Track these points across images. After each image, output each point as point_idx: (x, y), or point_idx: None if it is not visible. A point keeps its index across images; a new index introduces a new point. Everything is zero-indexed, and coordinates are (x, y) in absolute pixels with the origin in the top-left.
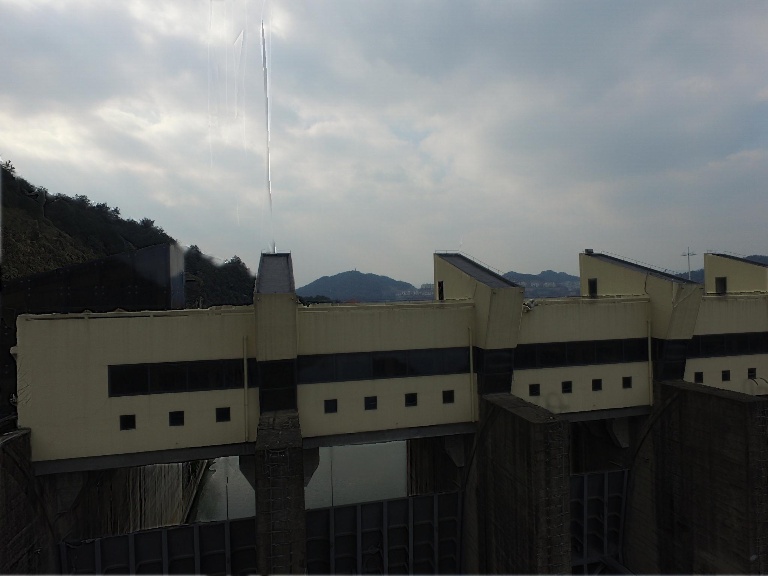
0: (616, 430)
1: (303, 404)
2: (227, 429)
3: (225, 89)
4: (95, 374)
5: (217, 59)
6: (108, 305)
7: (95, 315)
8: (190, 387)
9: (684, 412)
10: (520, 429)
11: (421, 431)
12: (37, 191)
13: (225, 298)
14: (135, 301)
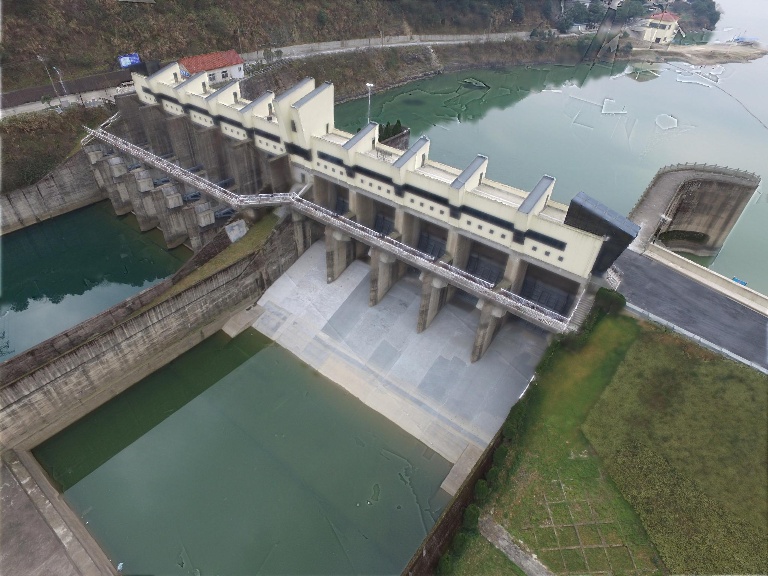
0: None
1: (163, 103)
2: None
3: None
4: (141, 87)
5: None
6: (143, 72)
7: (137, 75)
8: None
9: None
10: None
11: None
12: None
13: (459, 7)
14: None
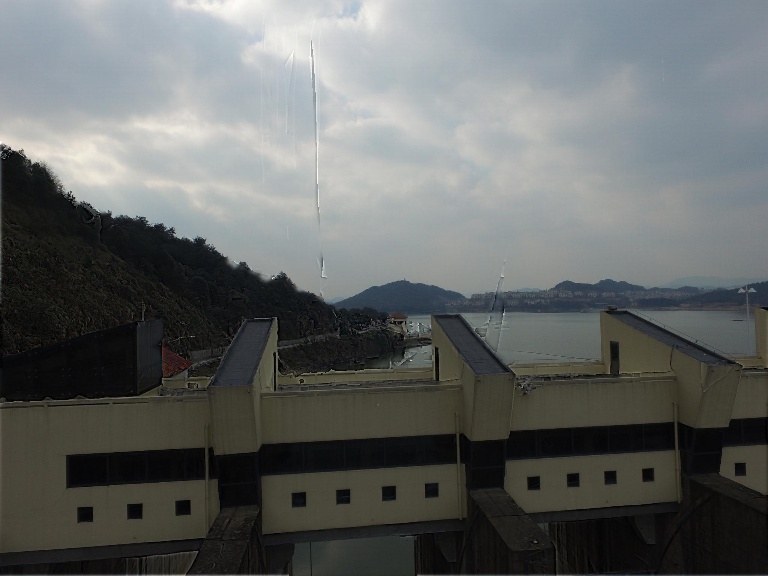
0: (639, 524)
1: (269, 497)
2: (187, 523)
3: (276, 108)
4: (54, 464)
5: (269, 80)
6: (75, 387)
7: (55, 403)
8: (149, 478)
9: (717, 519)
10: (500, 550)
11: (401, 528)
12: (94, 219)
13: (270, 314)
14: (102, 383)
